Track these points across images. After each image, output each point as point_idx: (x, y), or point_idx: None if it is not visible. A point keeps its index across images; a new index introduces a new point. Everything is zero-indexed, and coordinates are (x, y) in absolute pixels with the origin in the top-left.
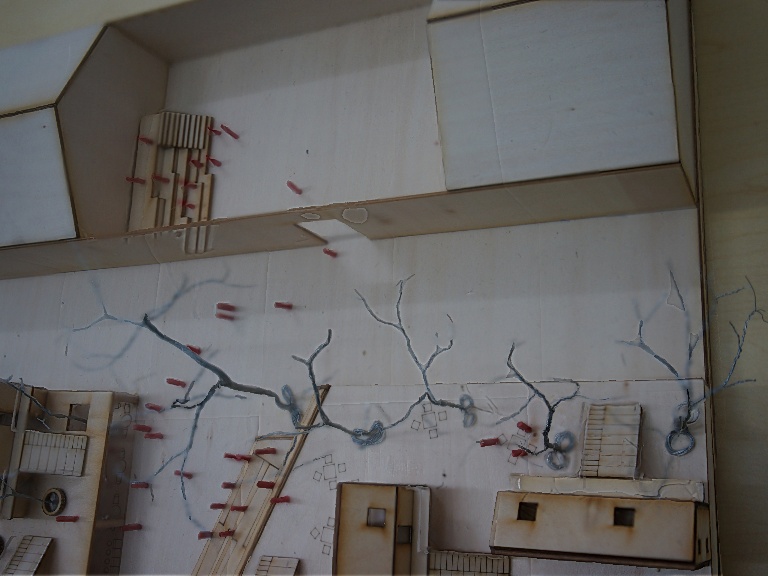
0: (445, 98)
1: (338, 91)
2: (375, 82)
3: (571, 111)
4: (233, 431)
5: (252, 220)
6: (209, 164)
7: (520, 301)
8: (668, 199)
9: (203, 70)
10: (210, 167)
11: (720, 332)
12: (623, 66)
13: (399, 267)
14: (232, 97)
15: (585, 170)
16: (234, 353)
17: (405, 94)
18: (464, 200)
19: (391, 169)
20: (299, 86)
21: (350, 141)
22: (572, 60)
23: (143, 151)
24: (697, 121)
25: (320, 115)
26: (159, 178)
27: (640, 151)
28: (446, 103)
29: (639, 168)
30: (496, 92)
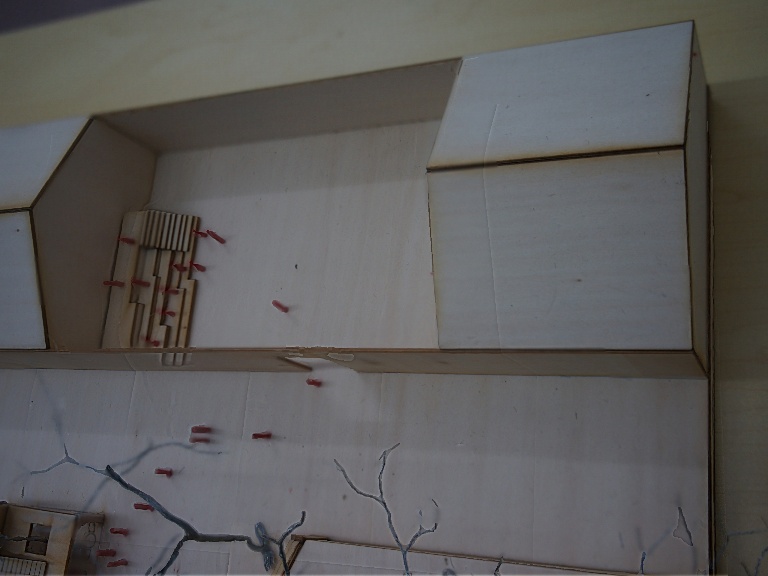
0: (442, 252)
1: (332, 204)
2: (371, 199)
3: (577, 282)
4: (201, 567)
5: (231, 353)
6: (193, 268)
7: (513, 460)
8: (677, 371)
9: (192, 164)
10: (194, 271)
11: (727, 514)
12: (636, 242)
13: (386, 406)
14: (221, 197)
15: (589, 346)
16: (207, 480)
17: (402, 216)
18: (458, 357)
19: (383, 296)
20: (291, 193)
21: (342, 260)
22: (581, 229)
23: (124, 251)
24: (712, 280)
25: (312, 228)
26: (139, 282)
27: (650, 333)
28: (443, 257)
29: (648, 351)
30: (497, 252)
